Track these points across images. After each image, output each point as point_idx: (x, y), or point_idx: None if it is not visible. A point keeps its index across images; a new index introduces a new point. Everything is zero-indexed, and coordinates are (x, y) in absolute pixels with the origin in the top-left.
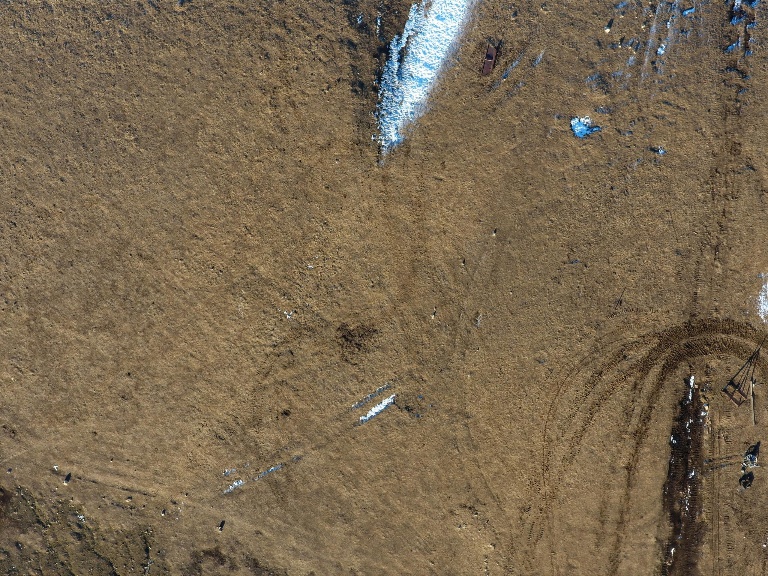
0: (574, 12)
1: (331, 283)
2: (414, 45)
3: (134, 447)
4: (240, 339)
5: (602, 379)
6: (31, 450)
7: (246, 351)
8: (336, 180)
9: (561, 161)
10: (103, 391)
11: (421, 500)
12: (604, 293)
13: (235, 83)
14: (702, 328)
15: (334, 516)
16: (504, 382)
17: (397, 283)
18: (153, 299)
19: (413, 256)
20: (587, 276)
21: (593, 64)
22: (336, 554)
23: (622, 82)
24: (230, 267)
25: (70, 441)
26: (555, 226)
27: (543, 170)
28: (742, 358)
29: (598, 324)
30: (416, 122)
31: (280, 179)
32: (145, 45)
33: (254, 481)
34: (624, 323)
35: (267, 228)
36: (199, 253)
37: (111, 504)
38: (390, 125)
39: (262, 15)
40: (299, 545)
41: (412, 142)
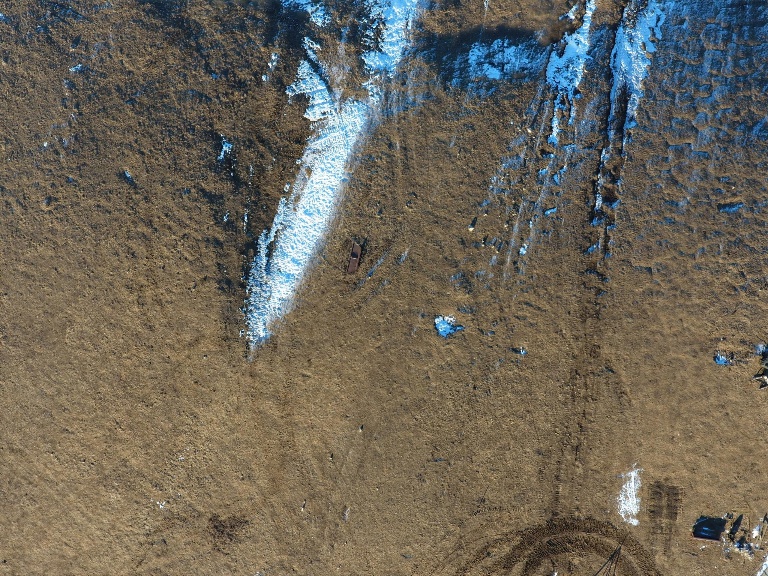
0: (438, 210)
1: (202, 474)
2: (283, 239)
3: None
4: (114, 528)
5: (467, 575)
6: None
7: (120, 540)
8: (205, 375)
9: (425, 360)
10: None
11: None
12: (467, 491)
13: (102, 282)
14: (564, 526)
15: None
16: (372, 575)
17: (267, 476)
18: (26, 490)
19: (282, 450)
20: (451, 474)
21: (457, 263)
22: None
23: (485, 282)
24: (101, 460)
25: None
26: (419, 424)
27: (408, 368)
28: (604, 556)
29: (462, 522)
30: (283, 318)
31: (149, 375)
32: (13, 244)
33: None
34: (487, 521)
35: (137, 422)
36: (70, 446)
37: None
38: (258, 320)
39: (129, 214)
40: None
41: (279, 339)
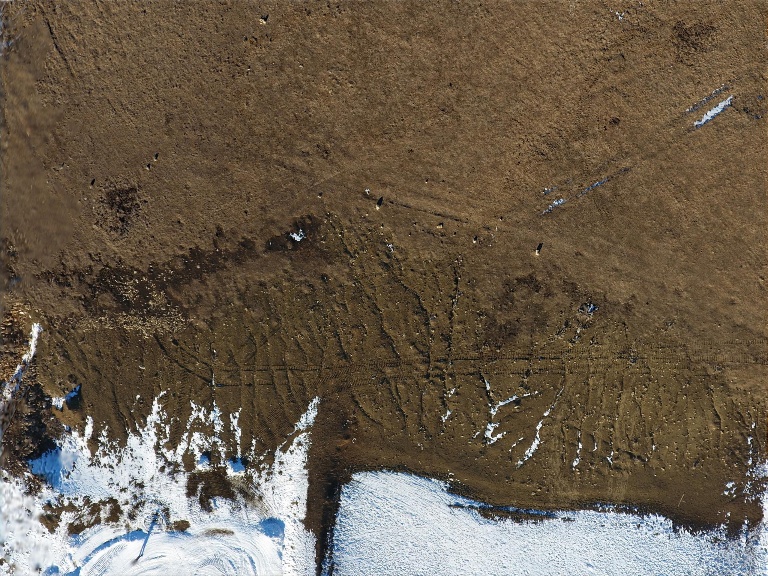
0: None
1: None
2: None
3: (451, 166)
4: (569, 43)
5: None
6: (343, 172)
7: (574, 56)
8: None
9: None
10: (422, 104)
11: (755, 210)
12: None
13: None
14: None
15: (662, 231)
16: None
17: None
18: (481, 0)
19: None
20: None
21: None
22: (661, 273)
23: None
24: None
25: (385, 161)
26: None
27: None
28: None
29: None
30: None
31: None
32: None
33: (577, 198)
34: None
35: None
36: None
37: (422, 231)
38: None
39: None
40: (622, 265)
41: None
